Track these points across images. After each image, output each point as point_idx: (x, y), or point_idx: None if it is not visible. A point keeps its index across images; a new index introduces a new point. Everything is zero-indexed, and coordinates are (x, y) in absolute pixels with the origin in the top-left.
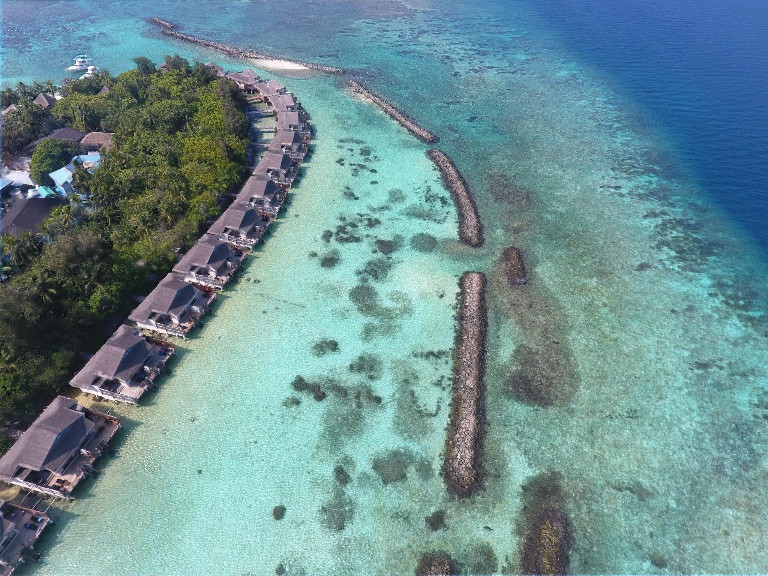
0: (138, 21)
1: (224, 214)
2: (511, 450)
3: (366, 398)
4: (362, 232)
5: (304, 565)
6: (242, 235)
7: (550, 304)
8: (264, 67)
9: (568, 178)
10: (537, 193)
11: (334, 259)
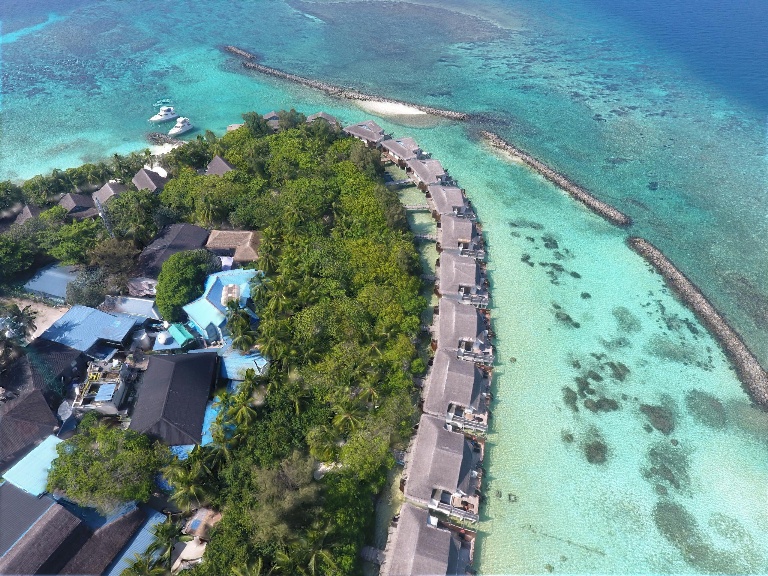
0: (210, 50)
1: (435, 374)
2: None
3: None
4: (614, 390)
5: None
6: (468, 410)
7: None
8: (375, 112)
9: None
10: None
11: (602, 447)
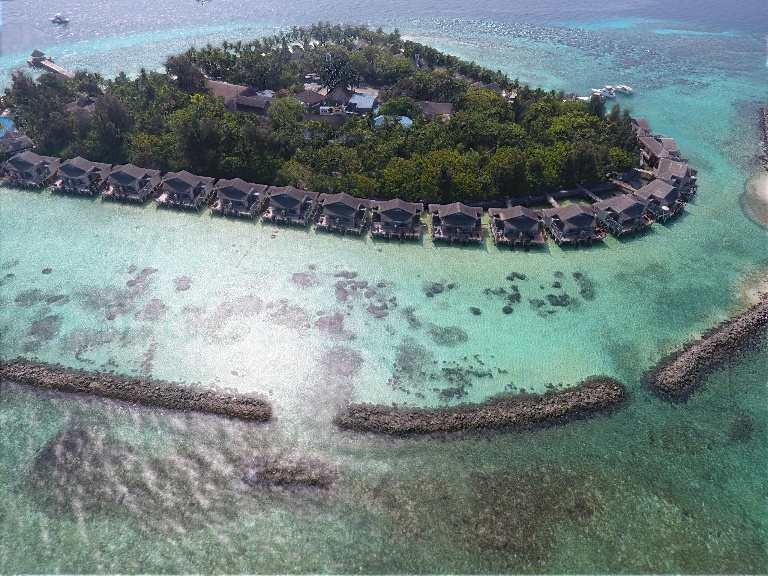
0: None
1: None
2: (8, 415)
3: (117, 310)
4: (357, 302)
5: (6, 285)
6: None
7: (196, 511)
8: (754, 187)
9: None
10: (540, 575)
11: (304, 281)
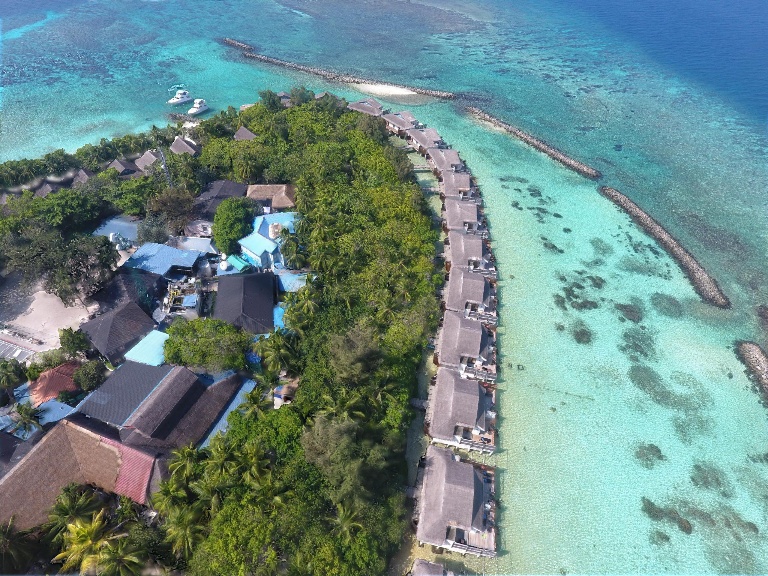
0: (209, 42)
1: (453, 283)
2: None
3: (739, 525)
4: (594, 295)
5: None
6: (480, 308)
7: None
8: (371, 93)
9: (761, 216)
10: (742, 236)
11: (587, 332)
